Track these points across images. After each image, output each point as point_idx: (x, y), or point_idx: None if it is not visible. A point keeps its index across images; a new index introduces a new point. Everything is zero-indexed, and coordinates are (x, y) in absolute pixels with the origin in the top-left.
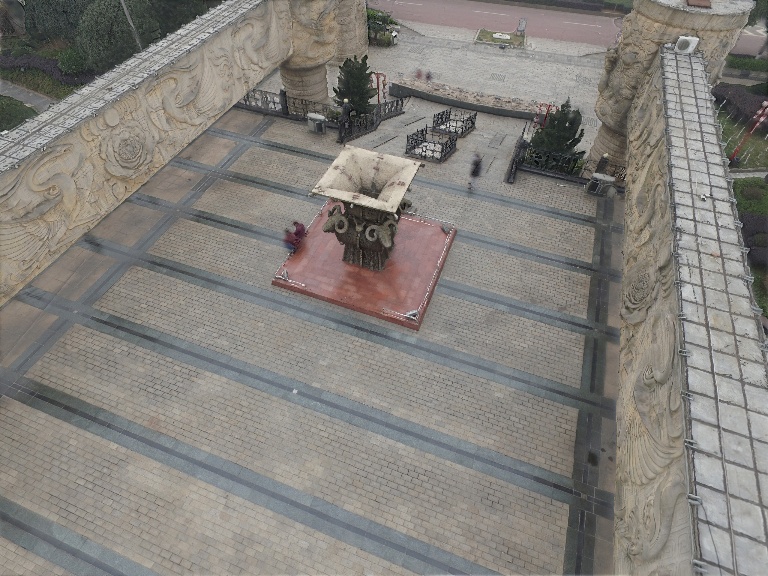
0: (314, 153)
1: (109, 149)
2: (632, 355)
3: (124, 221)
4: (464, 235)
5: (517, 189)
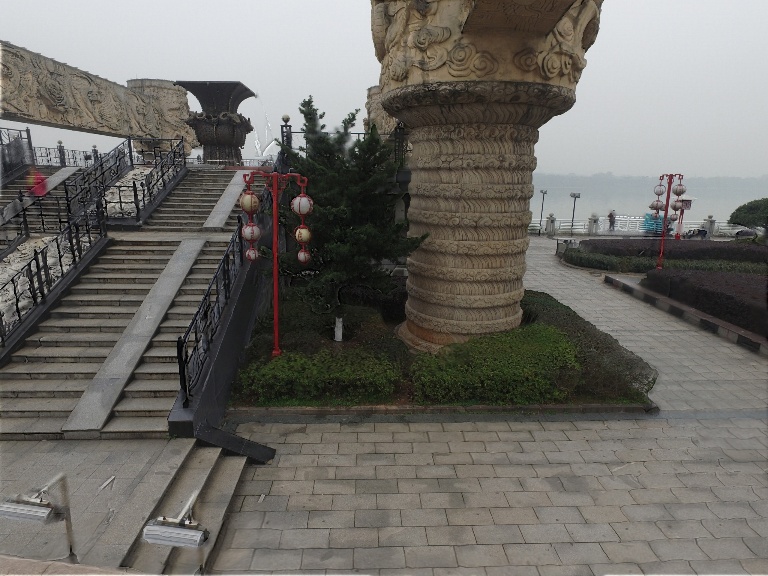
0: None
1: None
2: (78, 111)
3: None
4: None
5: None
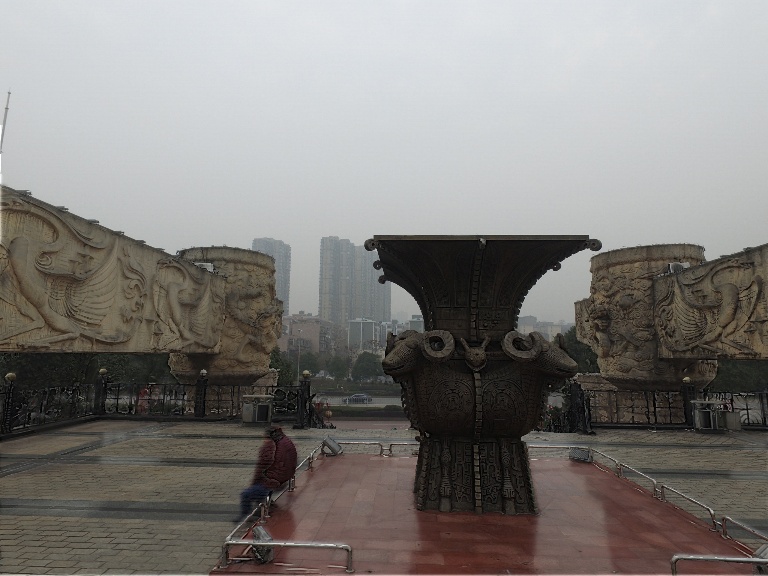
0: (258, 436)
1: None
2: None
3: None
4: (615, 470)
5: (610, 437)
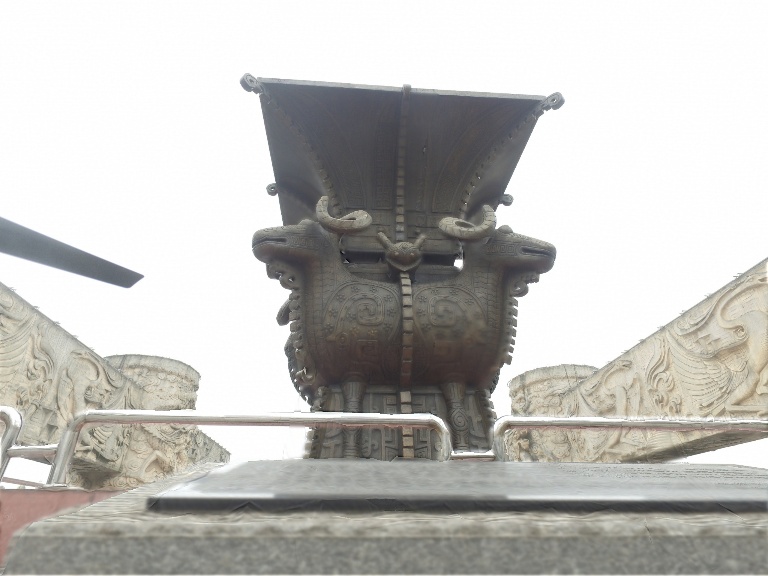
0: None
1: None
2: None
3: None
4: None
5: None
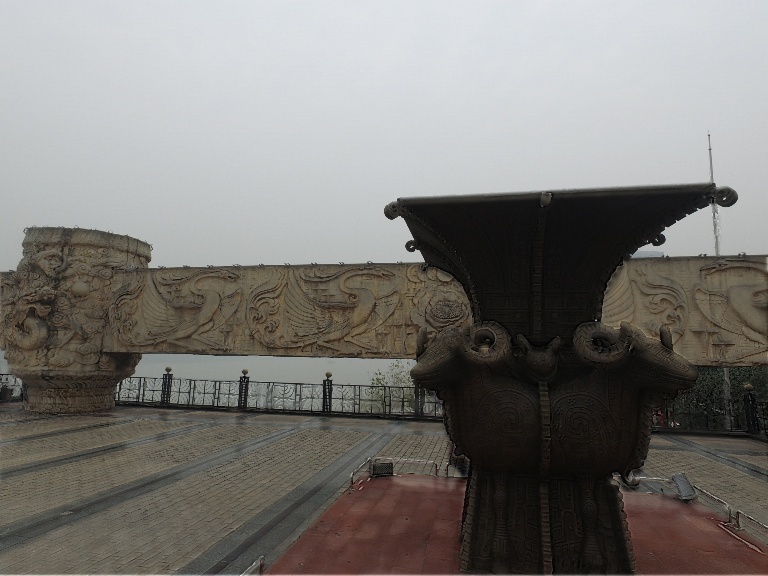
0: None
1: (425, 298)
2: None
3: (442, 426)
4: None
5: None
